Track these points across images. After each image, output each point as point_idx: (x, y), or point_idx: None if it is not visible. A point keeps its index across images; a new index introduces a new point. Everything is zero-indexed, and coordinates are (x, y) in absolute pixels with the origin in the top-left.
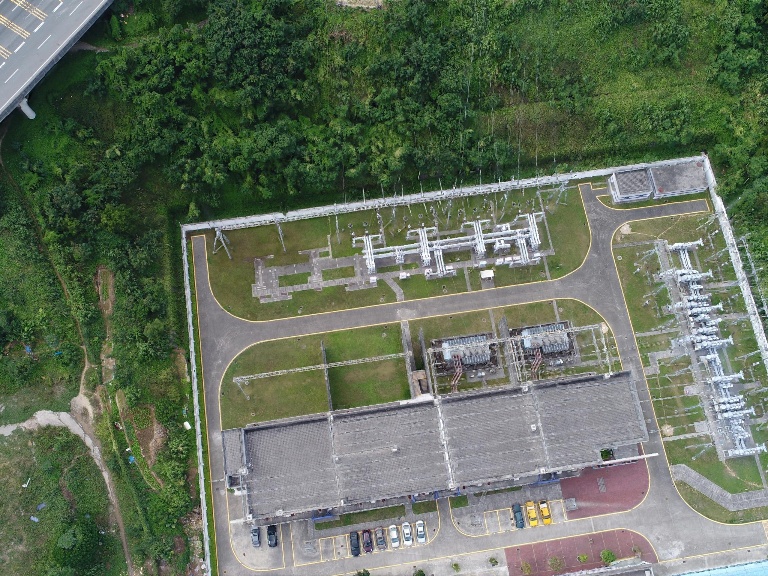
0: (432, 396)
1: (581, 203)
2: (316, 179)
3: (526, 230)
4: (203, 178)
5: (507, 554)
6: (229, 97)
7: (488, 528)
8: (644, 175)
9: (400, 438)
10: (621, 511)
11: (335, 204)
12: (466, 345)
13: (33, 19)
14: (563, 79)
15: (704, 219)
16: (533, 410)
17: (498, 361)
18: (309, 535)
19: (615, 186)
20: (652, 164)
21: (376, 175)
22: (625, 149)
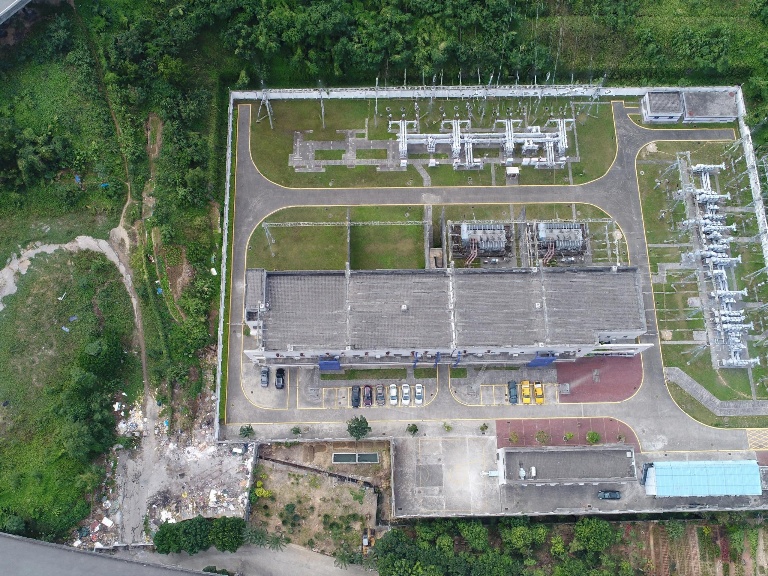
0: None
1: (612, 118)
2: (362, 59)
3: (555, 134)
4: (257, 44)
5: (498, 425)
6: None
7: (483, 400)
8: (676, 97)
9: (411, 300)
10: (611, 401)
11: (377, 78)
12: (484, 221)
13: None
14: None
15: (730, 147)
16: None
17: (512, 252)
18: (314, 383)
19: (647, 105)
20: (686, 89)
21: (419, 66)
22: (661, 73)
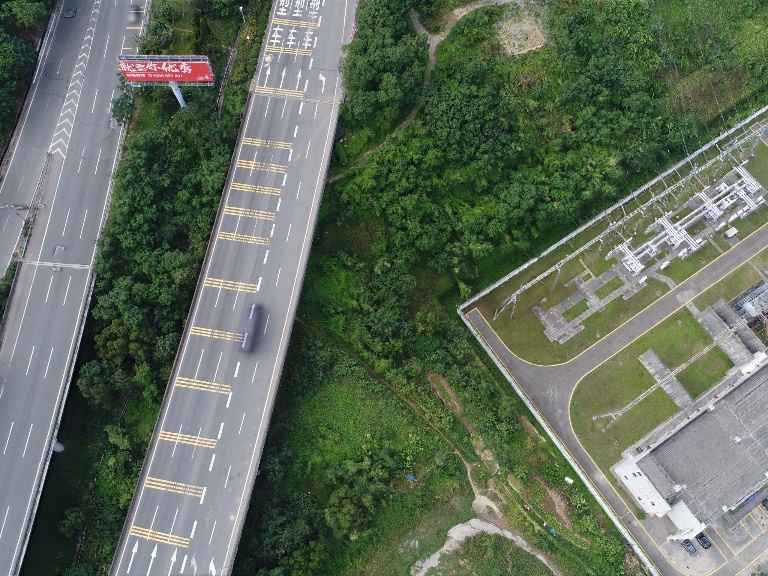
0: (763, 352)
1: (761, 142)
2: (565, 213)
3: (740, 182)
4: (474, 254)
5: None
6: (463, 173)
7: None
8: None
9: None
10: None
11: (611, 224)
12: None
13: (275, 175)
14: (706, 45)
15: None
16: None
17: None
18: (730, 522)
19: None
20: None
21: (599, 189)
22: None
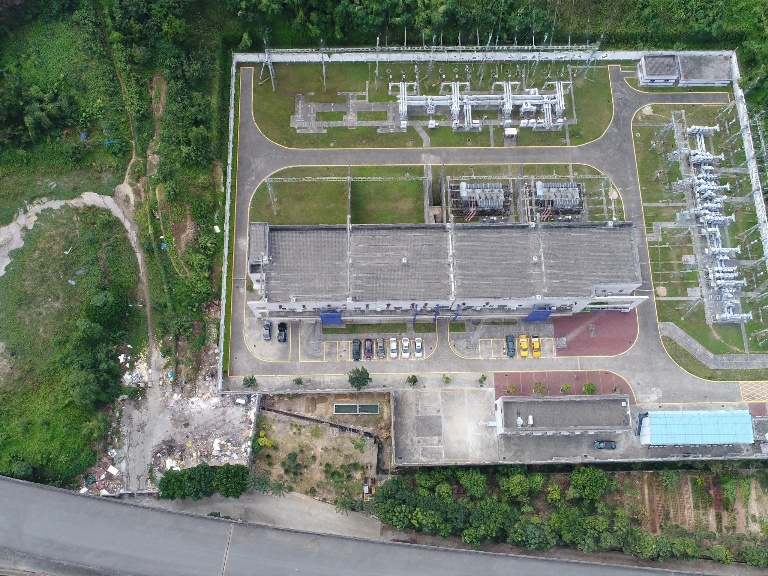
0: None
1: (608, 82)
2: (363, 21)
3: (553, 96)
4: (259, 6)
5: (496, 378)
6: None
7: (481, 353)
8: (672, 61)
9: (411, 253)
10: (607, 355)
11: (378, 38)
12: (483, 177)
13: None
14: None
15: None
16: (537, 245)
17: (510, 211)
18: (316, 337)
19: (643, 68)
20: (681, 53)
21: (419, 29)
22: (657, 37)
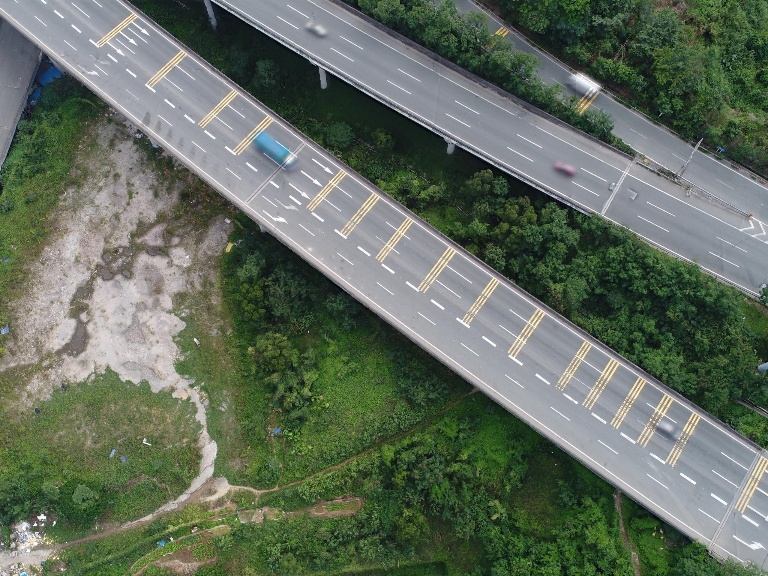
0: None
1: None
2: None
3: None
4: None
5: None
6: None
7: None
8: None
9: None
10: None
11: None
12: None
13: (639, 429)
14: None
15: None
16: None
17: None
18: None
19: None
20: None
21: None
22: None
